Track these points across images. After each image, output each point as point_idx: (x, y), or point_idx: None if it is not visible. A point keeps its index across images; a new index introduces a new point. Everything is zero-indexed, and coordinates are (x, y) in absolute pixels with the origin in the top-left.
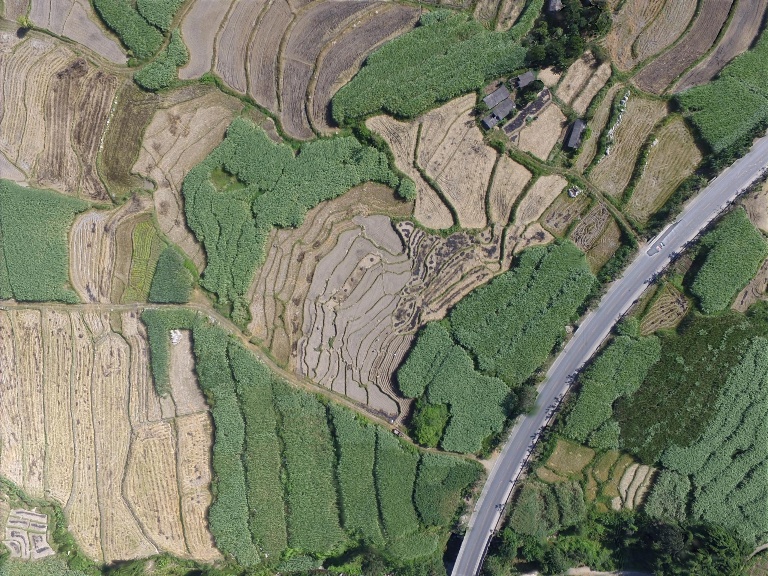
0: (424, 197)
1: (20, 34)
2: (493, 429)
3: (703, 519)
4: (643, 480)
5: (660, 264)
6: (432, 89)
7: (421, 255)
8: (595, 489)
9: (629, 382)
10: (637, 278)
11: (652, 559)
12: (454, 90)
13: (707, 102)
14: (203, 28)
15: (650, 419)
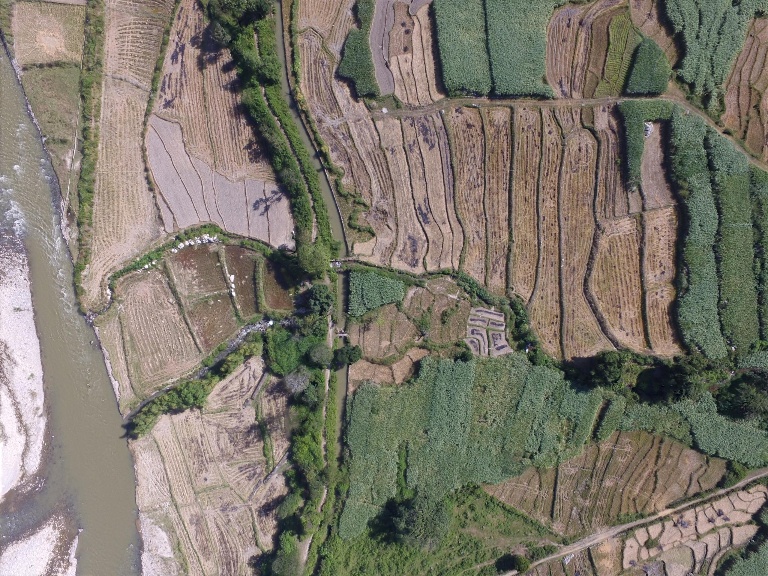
0: None
1: None
2: None
3: None
4: None
5: None
6: None
7: None
8: None
9: None
10: None
11: None
12: None
13: None
14: None
15: None
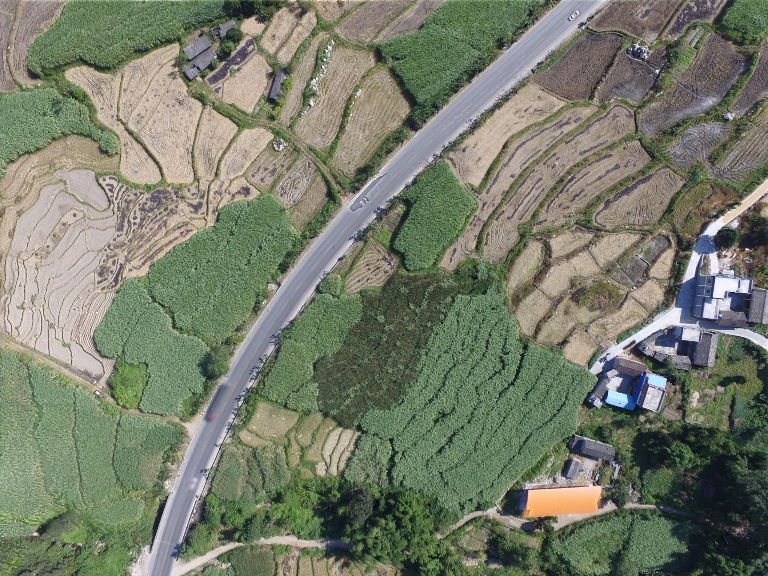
0: (130, 151)
1: None
2: (191, 390)
3: (403, 485)
4: (347, 445)
5: (365, 220)
6: (128, 38)
7: (125, 210)
8: (299, 454)
9: (329, 342)
10: (341, 234)
11: (344, 526)
12: (151, 39)
13: (409, 51)
14: None
15: (349, 380)
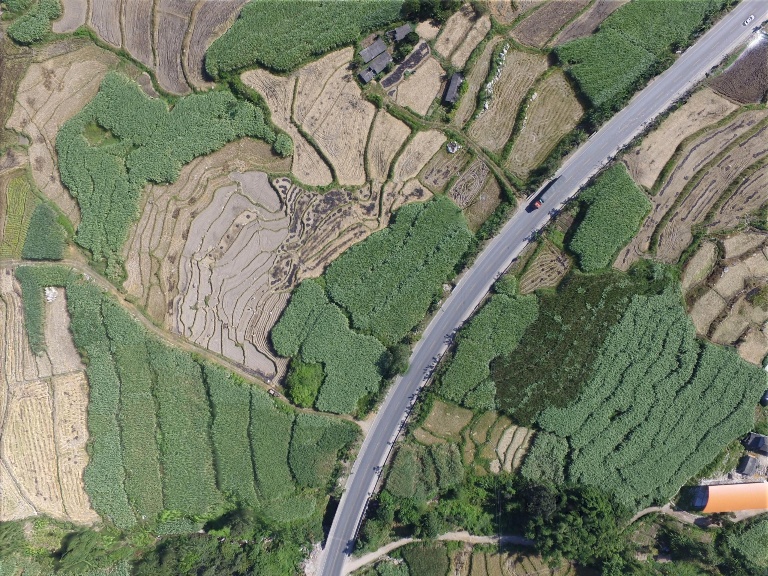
0: (302, 153)
1: None
2: (368, 389)
3: (580, 482)
4: (522, 442)
5: (540, 221)
6: (306, 42)
7: (298, 212)
8: (473, 451)
9: (506, 341)
10: (516, 235)
11: (525, 522)
12: (329, 43)
13: (586, 54)
14: None
15: (527, 379)
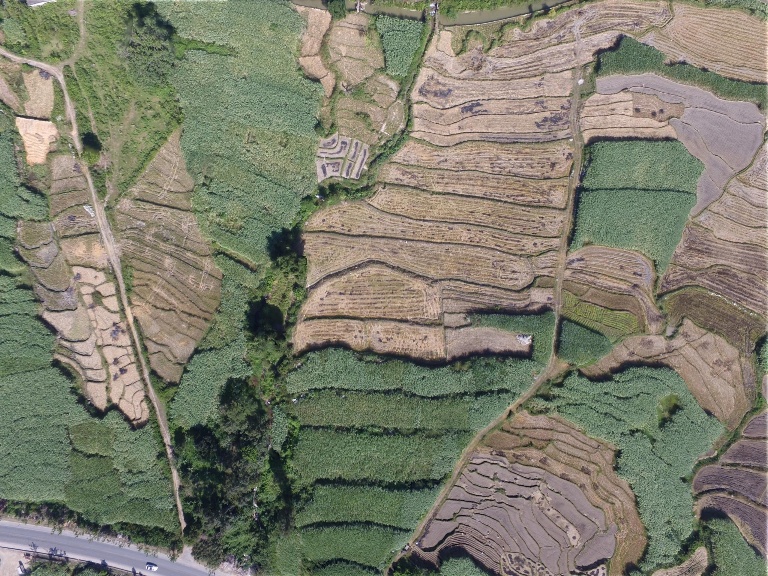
0: None
1: None
2: None
3: None
4: None
5: None
6: None
7: None
8: None
9: None
10: None
11: None
12: None
13: None
14: None
15: None
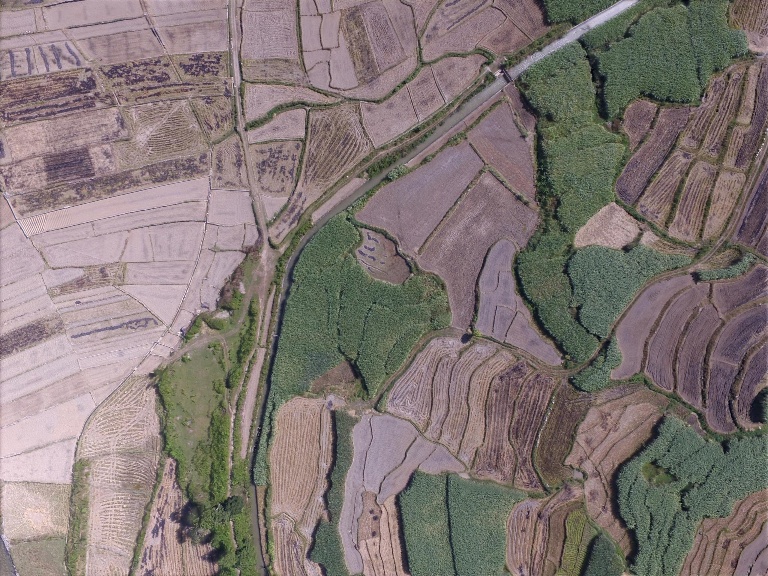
0: None
1: (464, 340)
2: None
3: None
4: None
5: None
6: None
7: None
8: None
9: None
10: None
11: None
12: None
13: None
14: (635, 333)
15: None
